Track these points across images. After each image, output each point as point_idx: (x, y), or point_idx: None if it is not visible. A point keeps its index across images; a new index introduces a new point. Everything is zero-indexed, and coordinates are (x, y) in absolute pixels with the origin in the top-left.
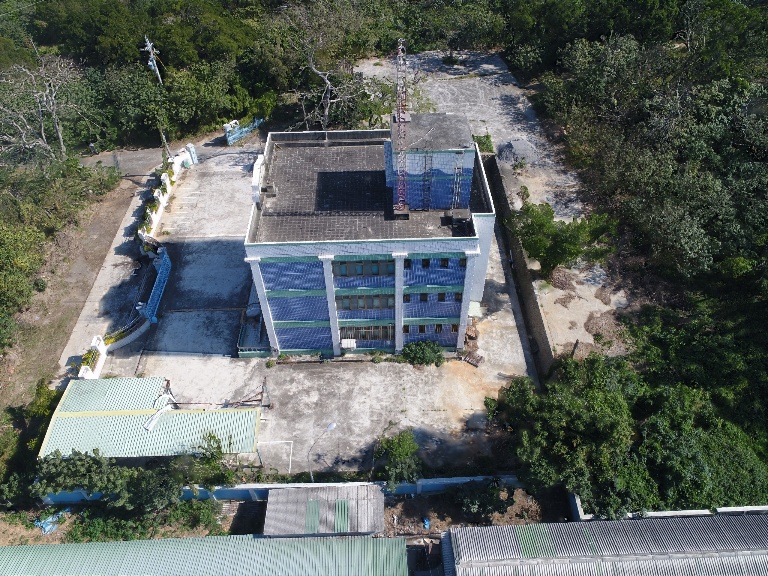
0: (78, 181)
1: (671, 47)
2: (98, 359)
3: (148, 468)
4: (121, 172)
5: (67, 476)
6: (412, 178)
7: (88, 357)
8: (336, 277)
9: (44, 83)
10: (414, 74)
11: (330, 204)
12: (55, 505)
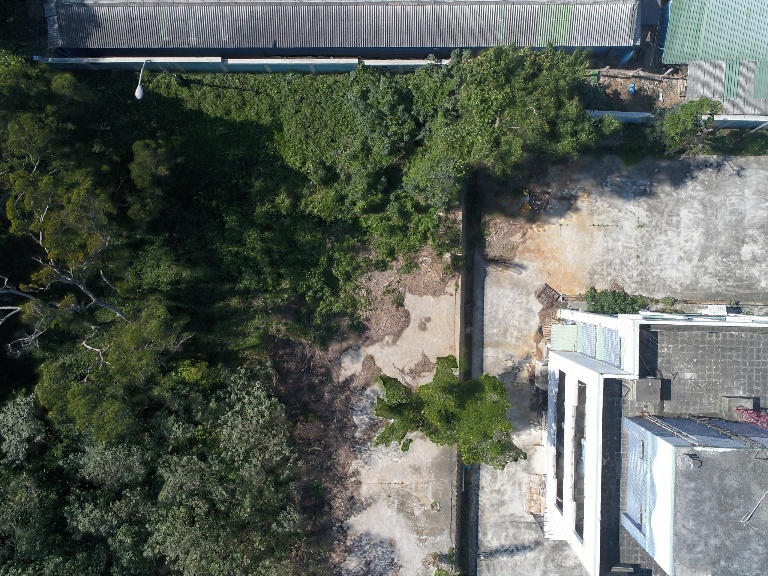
0: None
1: None
2: None
3: None
4: None
5: None
6: None
7: None
8: None
9: None
10: None
11: None
12: None
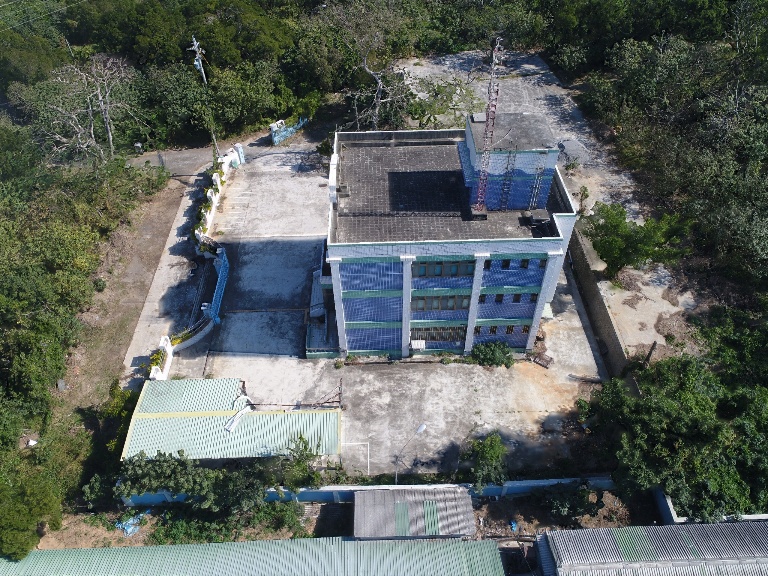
0: (126, 181)
1: (721, 47)
2: (166, 360)
3: (226, 469)
4: (169, 172)
5: (152, 478)
6: (492, 178)
7: (156, 358)
8: (414, 278)
9: (95, 82)
10: (455, 74)
11: (405, 204)
12: (135, 507)
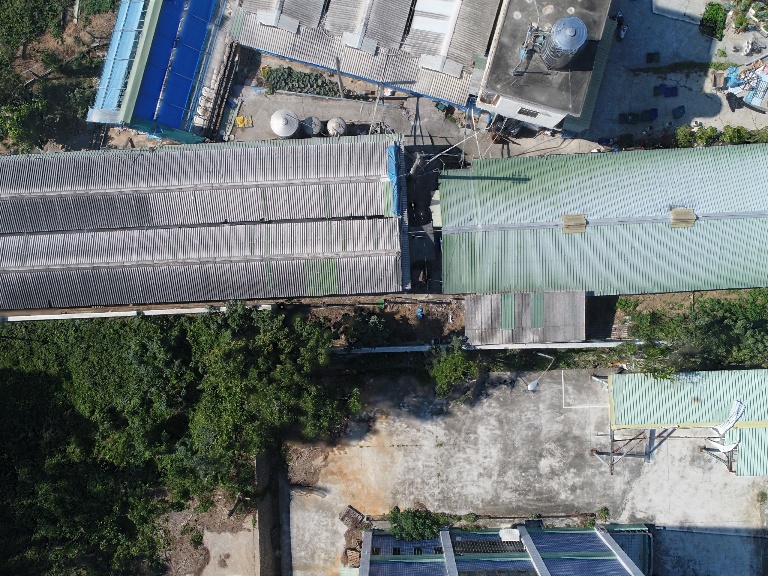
0: None
1: None
2: None
3: None
4: None
5: None
6: None
7: None
8: None
9: None
10: None
11: None
12: None
